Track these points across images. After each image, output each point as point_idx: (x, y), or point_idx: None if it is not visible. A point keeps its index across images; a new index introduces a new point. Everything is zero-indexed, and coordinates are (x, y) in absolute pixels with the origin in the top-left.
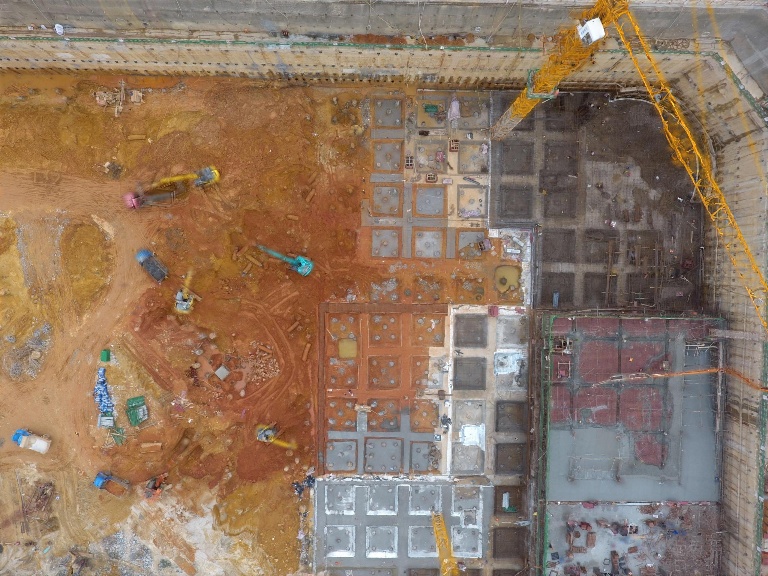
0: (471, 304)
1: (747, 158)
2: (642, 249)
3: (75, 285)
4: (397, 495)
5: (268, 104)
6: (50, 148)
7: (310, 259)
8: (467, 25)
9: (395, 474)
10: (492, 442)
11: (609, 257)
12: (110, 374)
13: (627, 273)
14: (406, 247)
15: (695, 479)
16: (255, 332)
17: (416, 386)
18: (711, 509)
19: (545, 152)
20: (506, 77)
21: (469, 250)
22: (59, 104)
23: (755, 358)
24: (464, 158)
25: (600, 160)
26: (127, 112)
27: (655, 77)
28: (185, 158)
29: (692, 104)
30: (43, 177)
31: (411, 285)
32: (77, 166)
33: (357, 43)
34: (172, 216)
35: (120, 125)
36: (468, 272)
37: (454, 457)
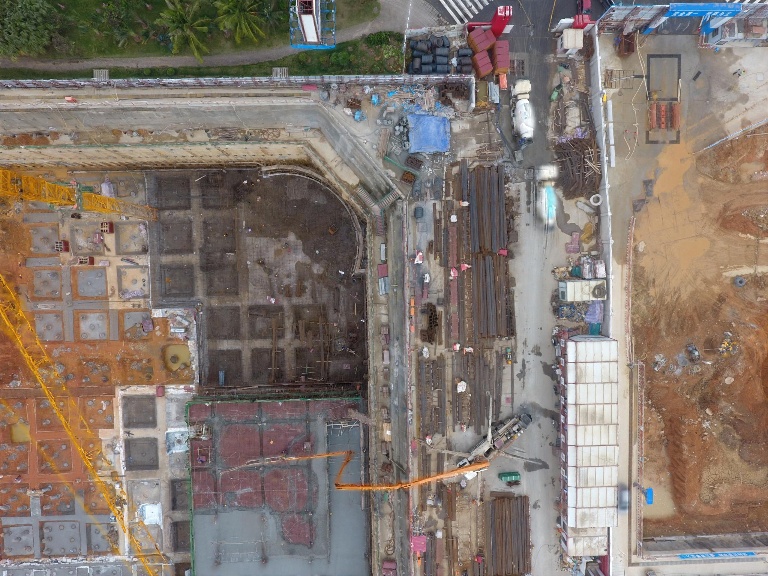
0: (139, 385)
1: None
2: (306, 324)
3: None
4: None
5: None
6: None
7: None
8: (37, 125)
9: (74, 556)
10: (168, 521)
11: (273, 333)
12: None
13: (294, 348)
14: (68, 331)
15: (345, 556)
16: None
17: None
18: None
19: (203, 230)
20: (138, 161)
21: (136, 330)
22: None
23: None
24: (124, 238)
25: (259, 236)
26: None
27: (287, 157)
28: None
29: None
30: None
31: (76, 368)
32: None
33: None
34: None
35: None
36: (133, 353)
37: (134, 536)
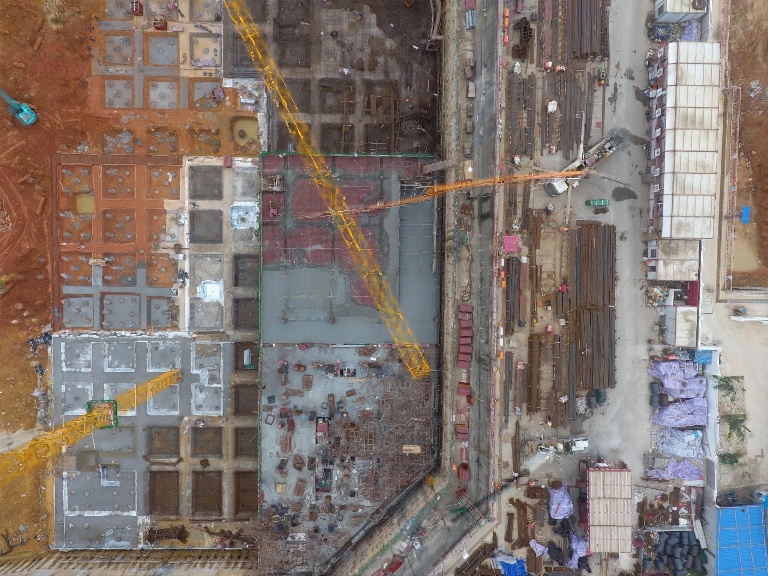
0: (206, 156)
1: None
2: (378, 98)
3: None
4: (135, 351)
5: None
6: None
7: (36, 107)
8: None
9: (133, 330)
10: (230, 297)
11: (344, 106)
12: None
13: (364, 124)
14: (138, 97)
15: (413, 321)
16: None
17: (153, 241)
18: (429, 351)
19: None
20: None
21: (205, 101)
22: None
23: (451, 185)
24: (198, 7)
25: (334, 7)
26: None
27: None
28: None
29: None
30: None
31: (144, 136)
32: None
33: None
34: None
35: None
36: (202, 123)
37: (194, 313)
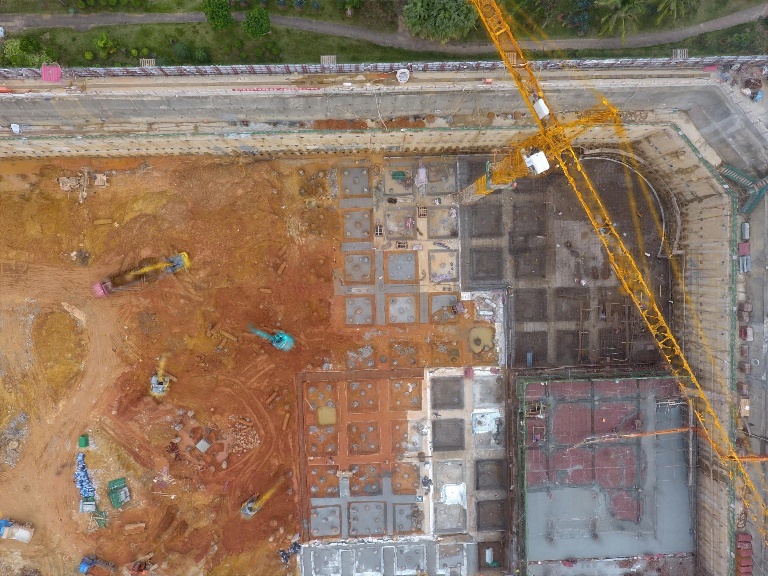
0: (447, 367)
1: (709, 220)
2: (612, 305)
3: (49, 372)
4: (382, 557)
5: (234, 181)
6: (15, 238)
7: (284, 331)
8: (426, 109)
9: (379, 536)
10: (473, 500)
11: (580, 315)
12: (89, 459)
13: (599, 329)
14: (380, 314)
15: (670, 532)
16: (233, 406)
17: (396, 449)
18: (687, 560)
19: (513, 214)
20: (470, 146)
21: (442, 313)
22: (22, 190)
23: (723, 418)
24: (433, 223)
25: (568, 219)
26: (92, 195)
27: (617, 140)
28: (153, 242)
29: (655, 164)
30: (10, 267)
31: (386, 351)
32: (44, 255)
33: (317, 129)
34: (143, 300)
35: (85, 210)
36: (442, 336)
37: (437, 516)
